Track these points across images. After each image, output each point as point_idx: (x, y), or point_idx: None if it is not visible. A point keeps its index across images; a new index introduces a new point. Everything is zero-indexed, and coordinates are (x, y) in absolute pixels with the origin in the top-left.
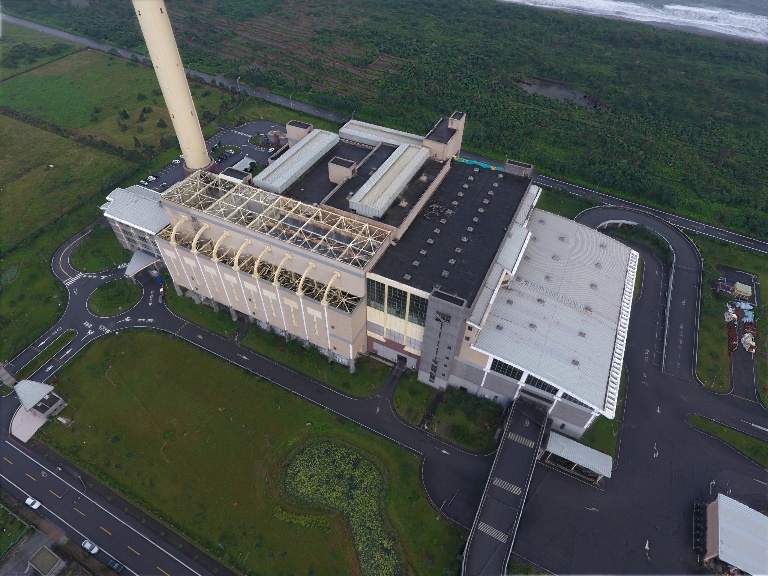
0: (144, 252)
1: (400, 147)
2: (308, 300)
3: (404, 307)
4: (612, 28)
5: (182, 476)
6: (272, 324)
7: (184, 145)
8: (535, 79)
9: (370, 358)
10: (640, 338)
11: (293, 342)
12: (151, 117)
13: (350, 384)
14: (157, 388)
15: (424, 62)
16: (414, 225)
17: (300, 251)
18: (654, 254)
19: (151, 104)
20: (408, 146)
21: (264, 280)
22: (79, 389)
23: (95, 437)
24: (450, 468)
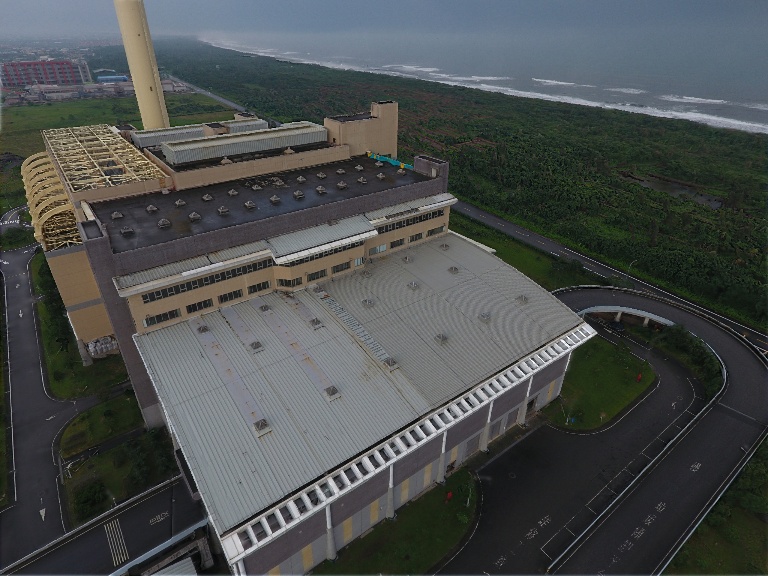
0: None
1: None
2: None
3: None
4: None
5: None
6: None
7: None
8: (653, 177)
9: None
10: (549, 491)
11: None
12: None
13: (65, 376)
14: None
15: (516, 146)
16: (220, 186)
17: None
18: (689, 378)
19: None
20: (307, 126)
21: None
22: None
23: None
24: (15, 540)
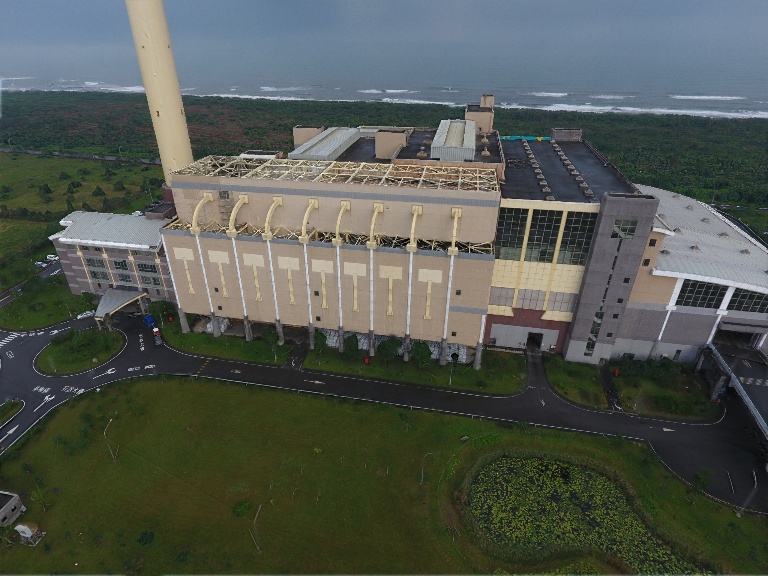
0: (120, 288)
1: (443, 121)
2: (423, 255)
3: (554, 240)
4: (512, 111)
5: (297, 570)
6: (348, 328)
7: (169, 154)
8: None
9: (489, 350)
10: None
11: (389, 341)
12: (82, 190)
13: (485, 381)
14: (194, 447)
15: None
16: (507, 171)
17: (399, 193)
18: None
19: (79, 181)
20: (450, 121)
21: (350, 244)
22: (45, 479)
23: (97, 549)
24: (692, 447)
